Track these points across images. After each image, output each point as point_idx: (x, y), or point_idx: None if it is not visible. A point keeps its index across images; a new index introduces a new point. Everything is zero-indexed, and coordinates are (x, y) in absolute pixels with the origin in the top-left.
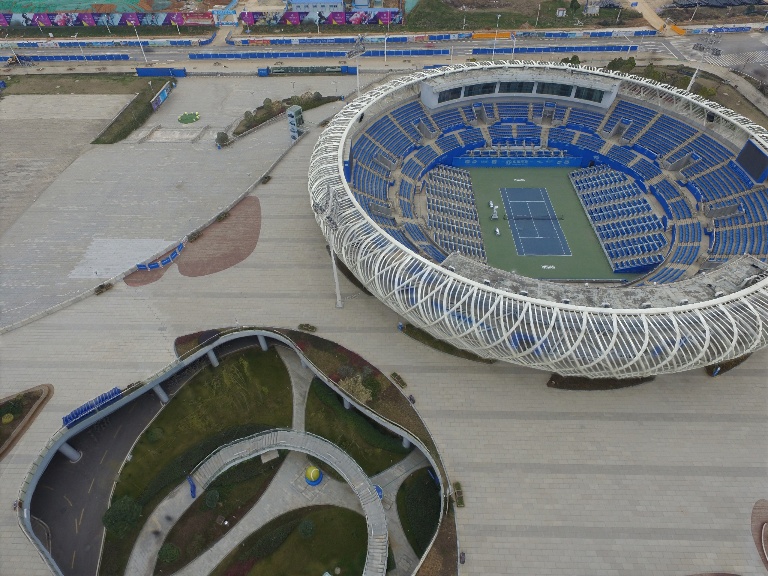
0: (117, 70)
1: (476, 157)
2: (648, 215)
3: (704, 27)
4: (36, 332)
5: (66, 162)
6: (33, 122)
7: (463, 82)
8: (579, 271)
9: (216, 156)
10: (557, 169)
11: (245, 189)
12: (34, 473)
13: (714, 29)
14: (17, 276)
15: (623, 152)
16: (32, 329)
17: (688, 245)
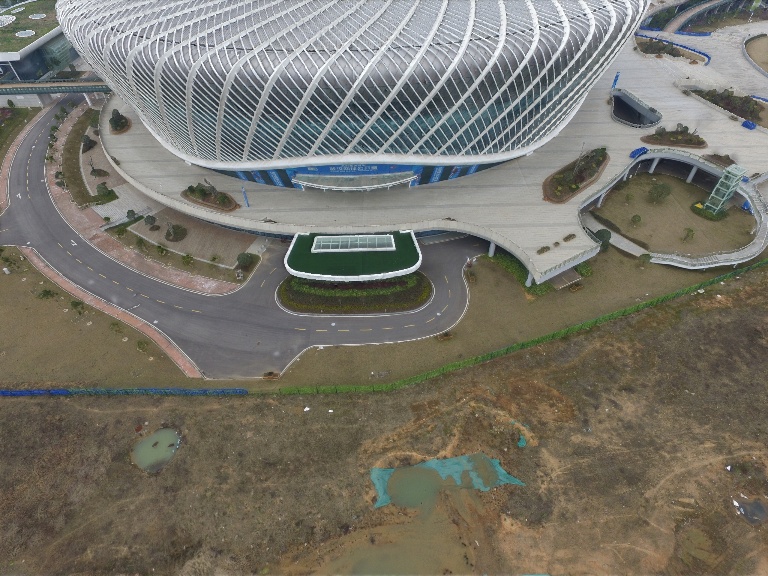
0: None
1: None
2: None
3: None
4: None
5: None
6: None
7: None
8: None
9: None
10: None
11: None
12: None
13: None
14: None
15: None
16: None
17: None
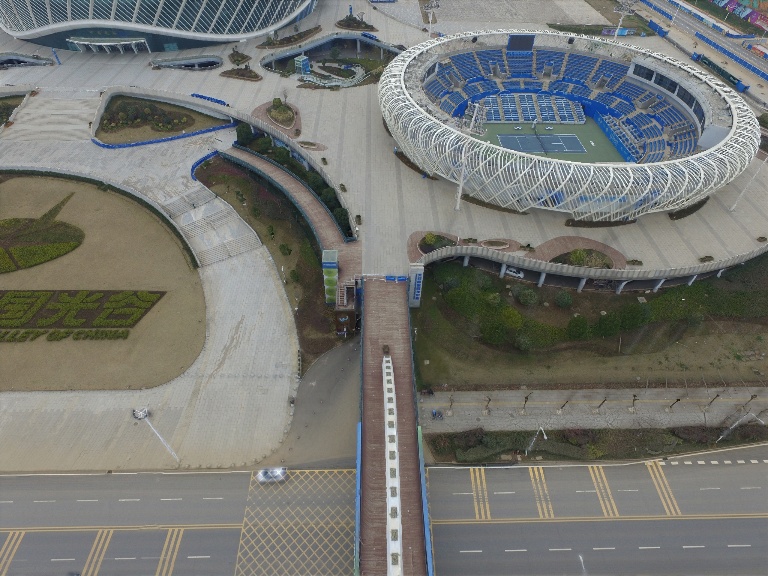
0: None
1: None
2: None
3: None
4: None
5: (525, 21)
6: (558, 9)
7: (659, 69)
8: None
9: None
10: None
11: None
12: (346, 34)
13: None
14: None
15: None
16: None
17: None
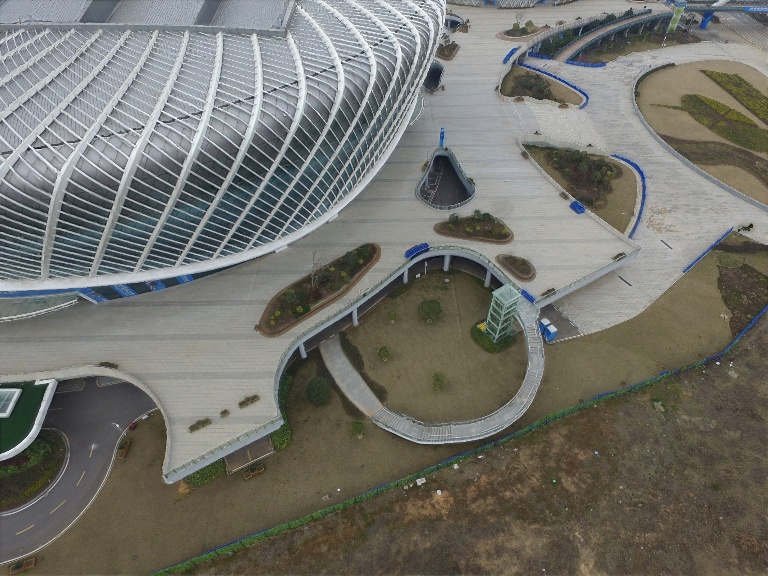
0: None
1: None
2: None
3: None
4: None
5: None
6: None
7: None
8: None
9: None
10: None
11: None
12: None
13: None
14: None
15: None
16: None
17: None
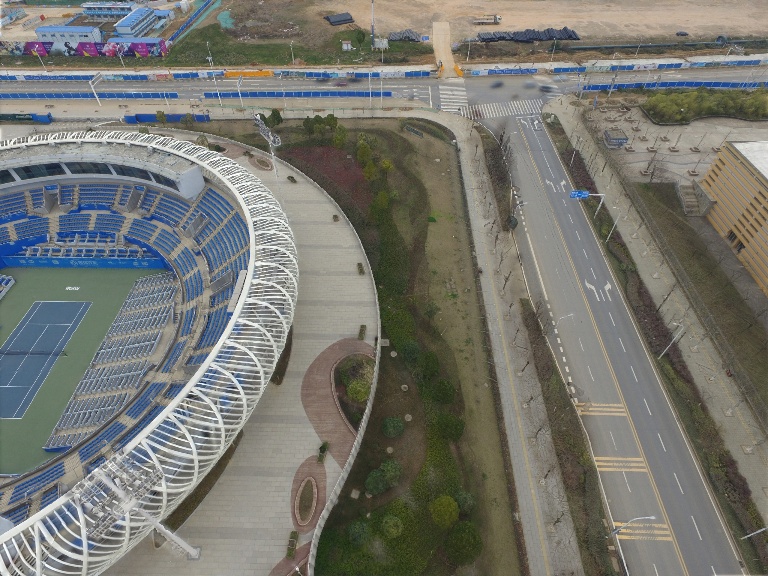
0: None
1: (29, 256)
2: (140, 361)
3: (494, 66)
4: None
5: None
6: None
7: (8, 163)
8: (5, 447)
9: None
10: (135, 271)
11: None
12: None
13: (495, 71)
14: None
15: (188, 258)
16: None
17: (124, 422)
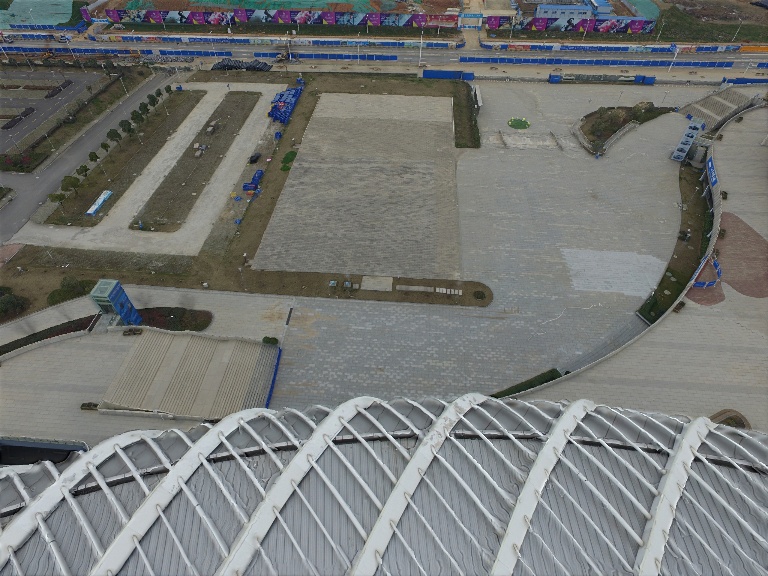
0: (394, 71)
1: None
2: None
3: None
4: (655, 350)
5: (450, 165)
6: (375, 122)
7: None
8: None
9: (601, 166)
10: None
11: (668, 202)
12: None
13: None
14: (520, 285)
15: None
16: (647, 347)
17: None
